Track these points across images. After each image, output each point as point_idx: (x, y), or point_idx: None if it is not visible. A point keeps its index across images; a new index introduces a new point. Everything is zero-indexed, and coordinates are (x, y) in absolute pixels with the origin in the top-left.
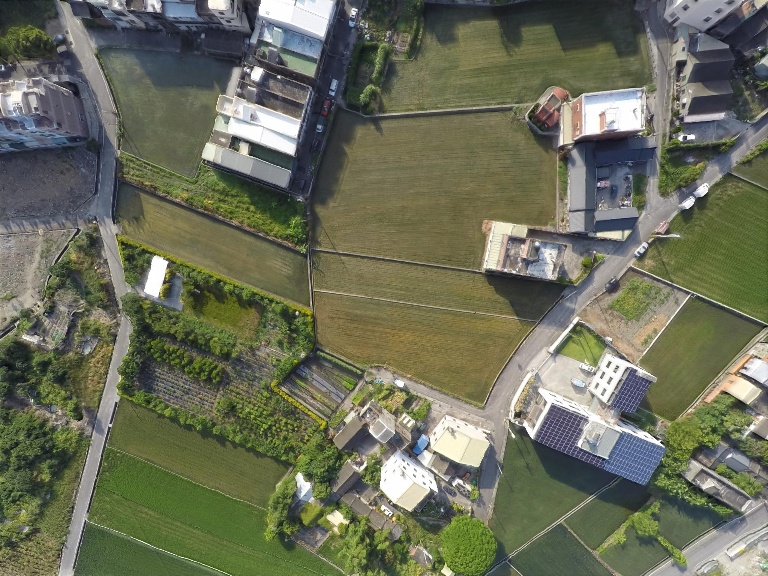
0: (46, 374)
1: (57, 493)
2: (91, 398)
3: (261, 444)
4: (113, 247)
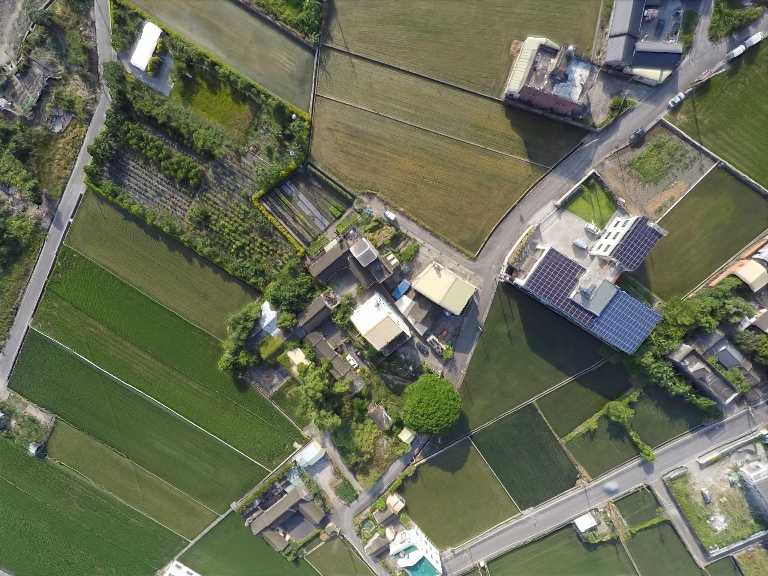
0: (9, 145)
1: (2, 290)
2: (54, 185)
3: (230, 260)
4: (104, 8)
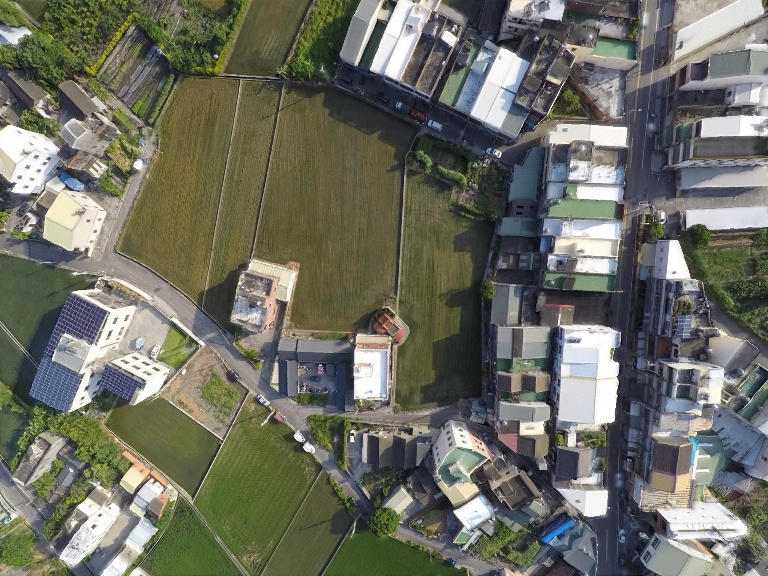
0: None
1: None
2: None
3: None
4: None
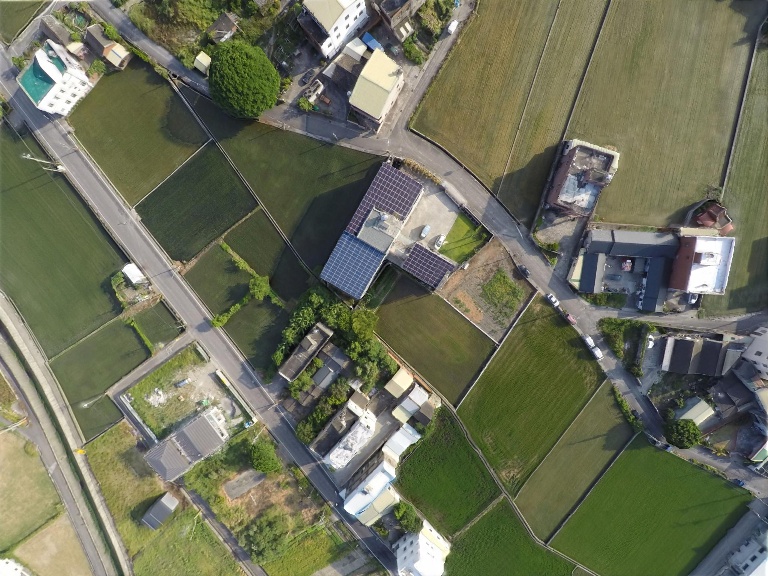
0: None
1: None
2: None
3: None
4: None
